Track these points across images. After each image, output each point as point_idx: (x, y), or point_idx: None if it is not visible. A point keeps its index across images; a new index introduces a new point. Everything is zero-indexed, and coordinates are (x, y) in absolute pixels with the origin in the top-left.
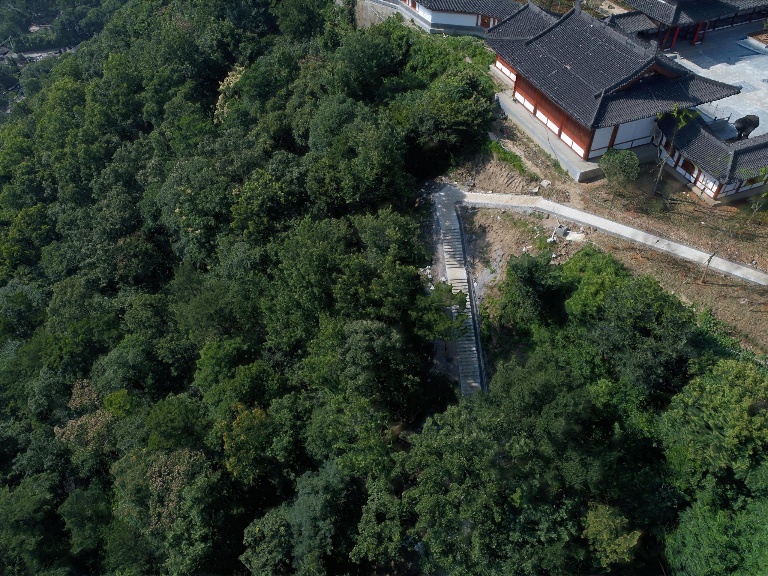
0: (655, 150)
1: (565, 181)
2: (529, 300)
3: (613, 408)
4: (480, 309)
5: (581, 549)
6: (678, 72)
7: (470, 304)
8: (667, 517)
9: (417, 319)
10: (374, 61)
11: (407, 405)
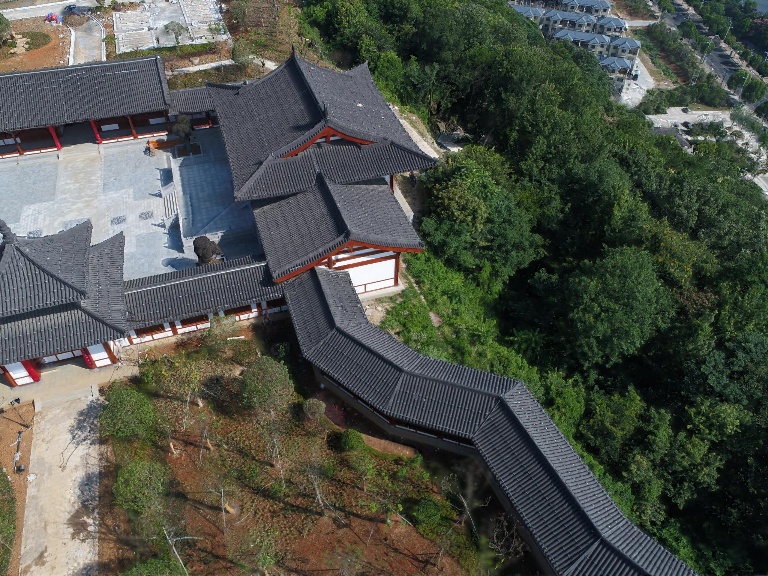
0: None
1: None
2: None
3: None
4: None
5: None
6: None
7: None
8: None
9: None
10: None
11: None
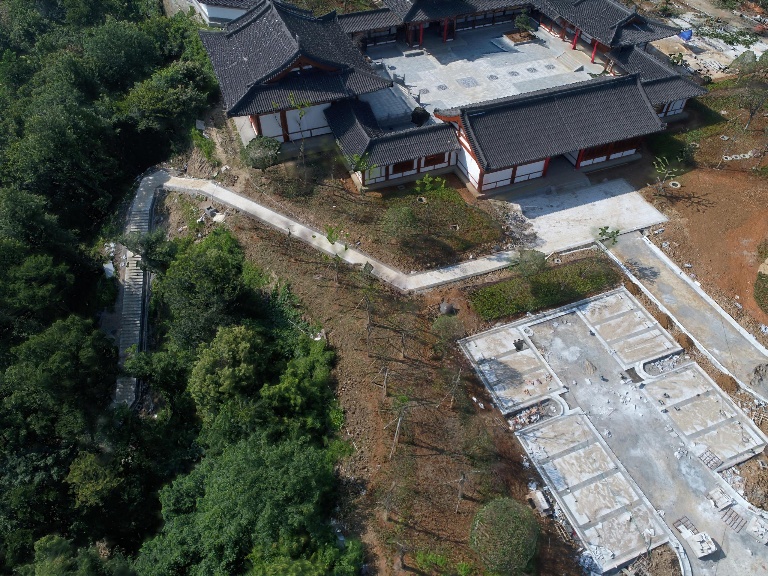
0: (333, 139)
1: (242, 167)
2: (158, 275)
3: (188, 373)
4: (153, 285)
5: (53, 491)
6: (336, 65)
7: (143, 281)
8: (182, 469)
9: (7, 288)
10: (122, 52)
11: None
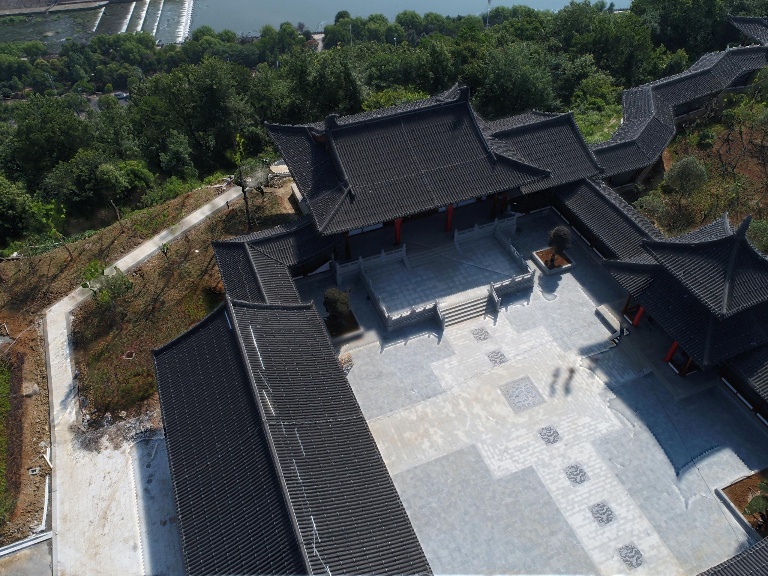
0: None
1: None
2: None
3: None
4: None
5: None
6: (343, 175)
7: None
8: None
9: None
10: (492, 75)
11: (150, 160)
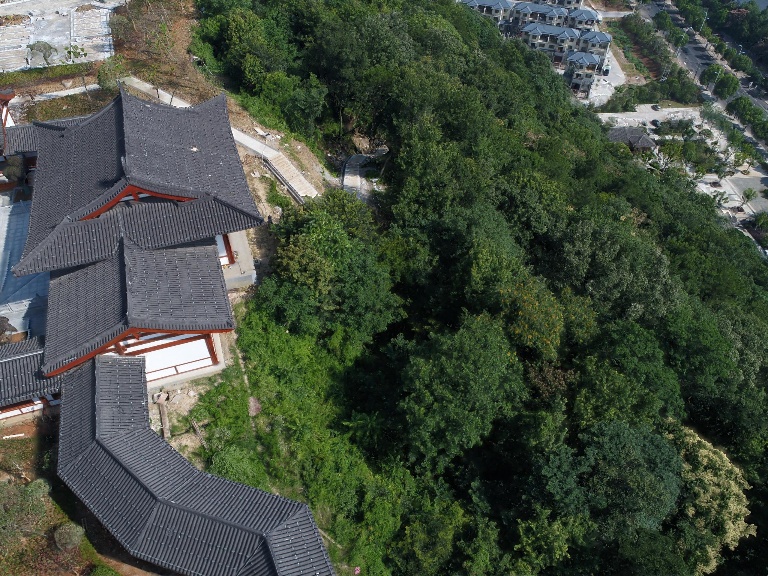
0: None
1: None
2: None
3: None
4: None
5: None
6: None
7: None
8: None
9: None
10: None
11: None
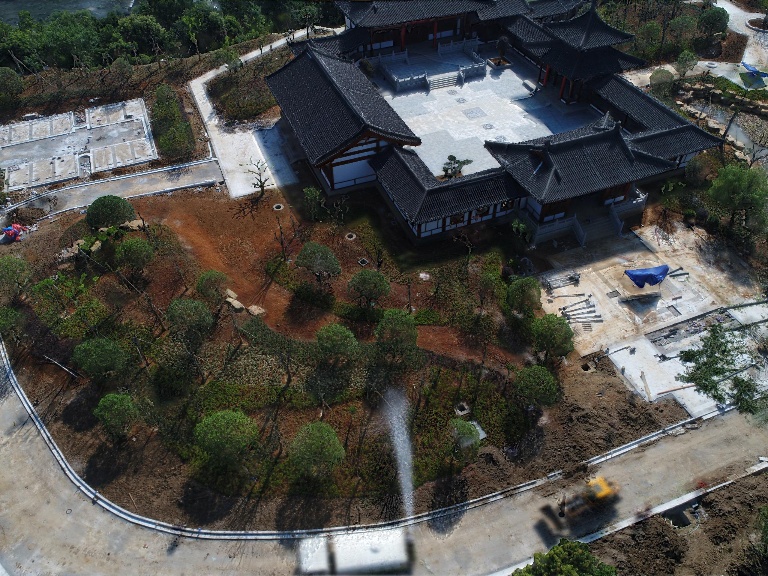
0: None
1: None
2: None
3: None
4: None
5: None
6: None
7: None
8: None
9: None
10: None
11: None
